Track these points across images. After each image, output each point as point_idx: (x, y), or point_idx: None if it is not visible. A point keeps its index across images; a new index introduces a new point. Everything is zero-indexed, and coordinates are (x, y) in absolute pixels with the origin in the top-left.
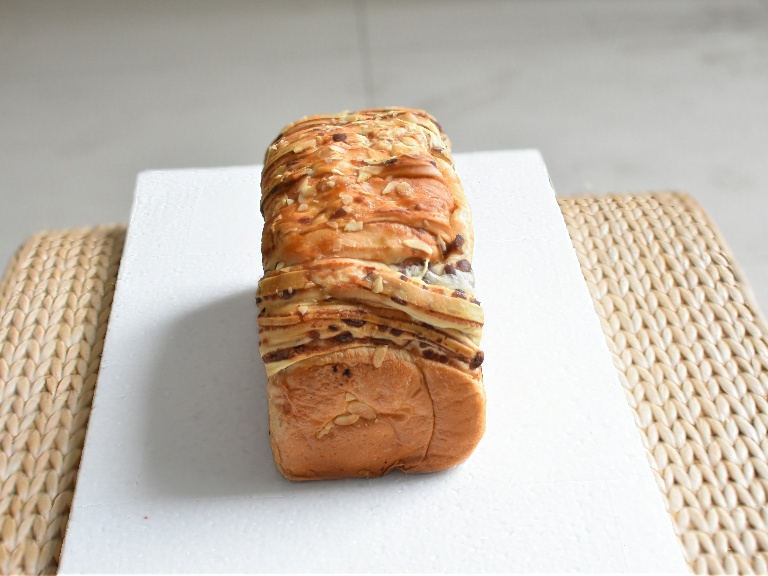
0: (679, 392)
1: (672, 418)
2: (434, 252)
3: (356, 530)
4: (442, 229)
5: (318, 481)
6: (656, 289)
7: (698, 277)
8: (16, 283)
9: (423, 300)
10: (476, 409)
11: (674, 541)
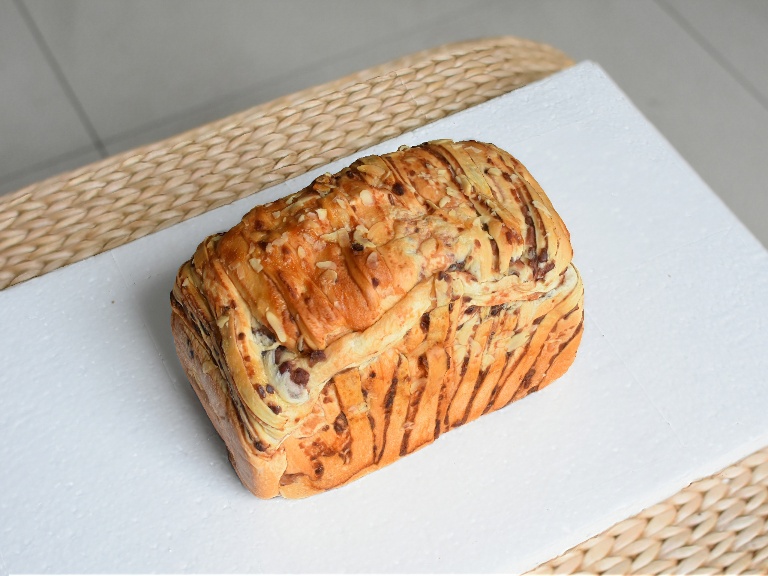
0: None
1: None
2: (289, 343)
3: (148, 450)
4: (309, 334)
5: None
6: None
7: None
8: (406, 66)
9: (233, 364)
10: (252, 475)
11: None
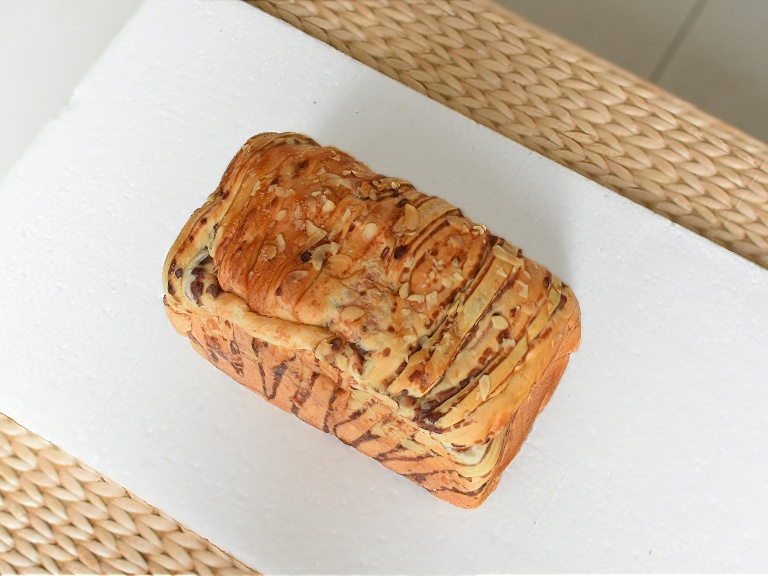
0: None
1: (153, 568)
2: None
3: None
4: None
5: None
6: None
7: None
8: None
9: (182, 231)
10: None
11: (3, 404)
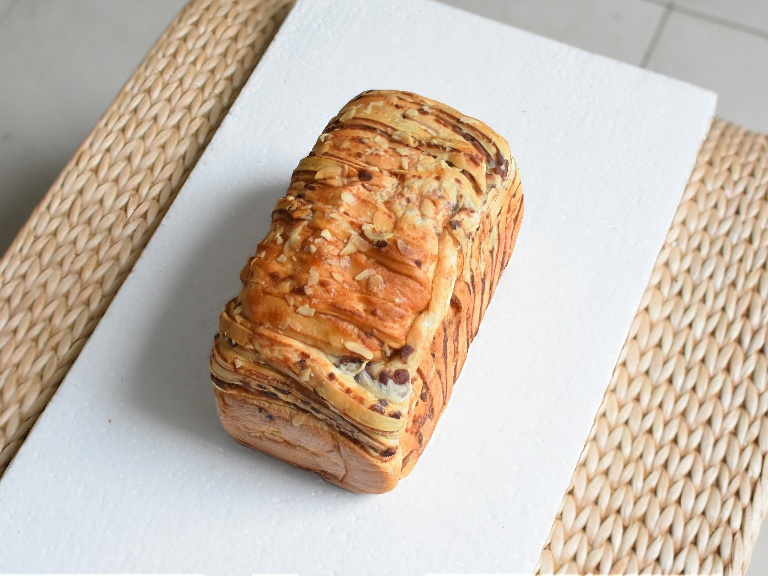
0: (640, 481)
1: (612, 509)
2: (376, 356)
3: (254, 520)
4: (391, 339)
5: (256, 450)
6: (715, 337)
7: (764, 343)
8: (161, 58)
9: (340, 404)
10: (383, 479)
11: None
